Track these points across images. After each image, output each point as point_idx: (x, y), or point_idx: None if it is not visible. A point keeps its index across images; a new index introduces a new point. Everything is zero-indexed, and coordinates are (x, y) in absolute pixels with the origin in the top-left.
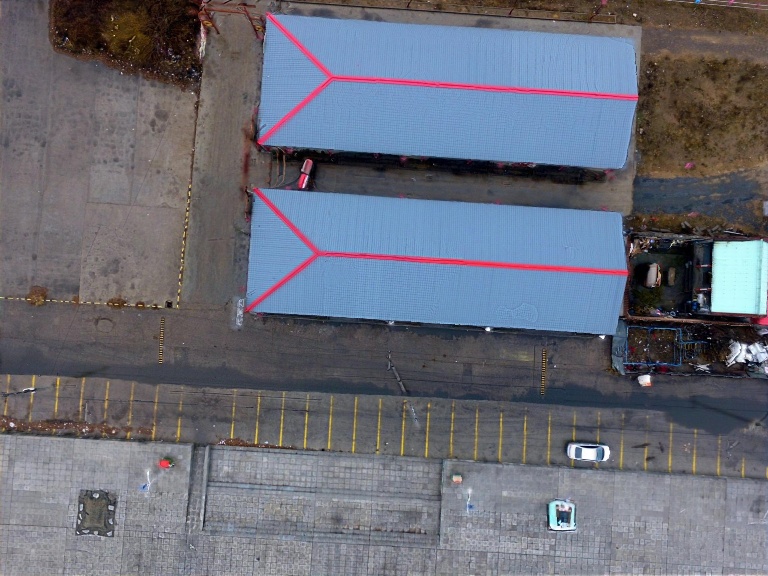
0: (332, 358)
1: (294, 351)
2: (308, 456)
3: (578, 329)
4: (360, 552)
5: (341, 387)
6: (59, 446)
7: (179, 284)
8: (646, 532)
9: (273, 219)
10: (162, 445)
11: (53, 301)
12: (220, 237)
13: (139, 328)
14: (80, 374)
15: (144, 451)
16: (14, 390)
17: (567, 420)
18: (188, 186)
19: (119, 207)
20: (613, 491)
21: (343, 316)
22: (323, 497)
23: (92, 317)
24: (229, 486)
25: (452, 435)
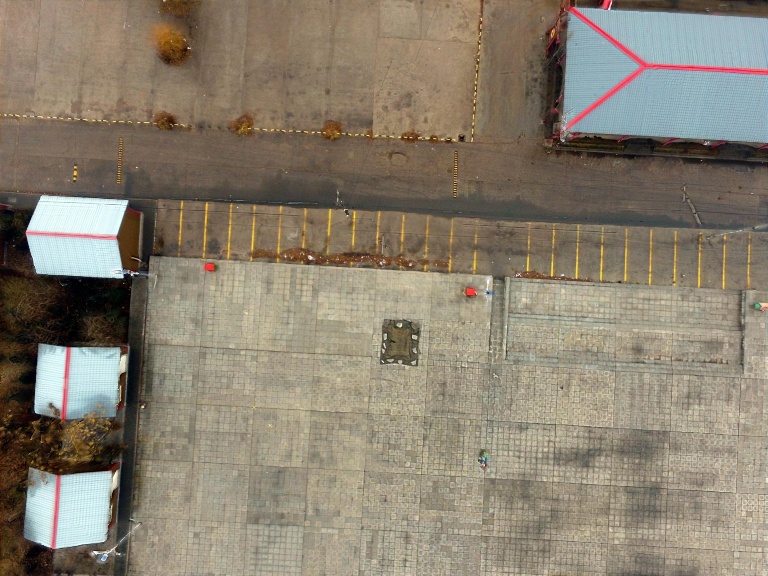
0: (626, 191)
1: (588, 184)
2: (606, 288)
3: None
4: (663, 381)
5: None
6: (362, 276)
7: (473, 117)
8: None
9: (593, 35)
10: (463, 275)
11: (348, 135)
12: (512, 70)
13: (433, 162)
14: (375, 208)
15: (446, 281)
16: (311, 224)
17: None
18: (479, 19)
19: (410, 41)
20: None
21: (660, 135)
22: (623, 327)
23: (386, 151)
24: (528, 317)
25: (749, 267)
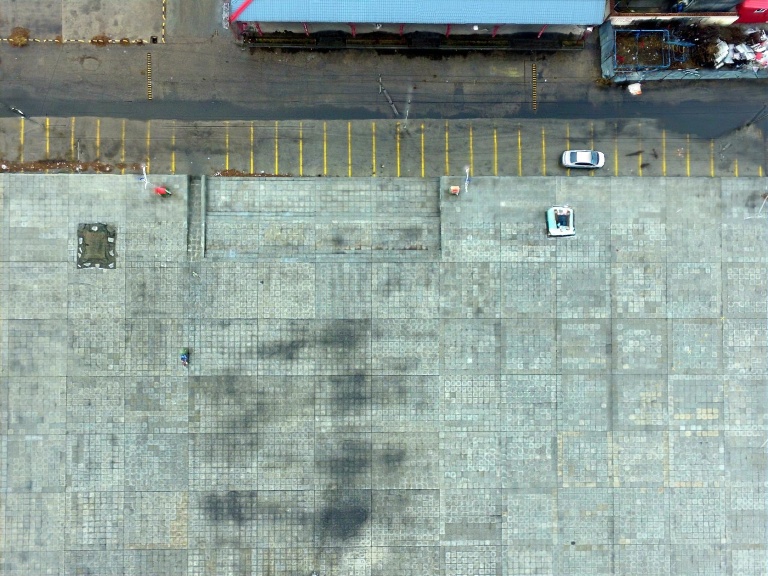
0: (322, 85)
1: (284, 79)
2: (305, 182)
3: (566, 20)
4: (363, 270)
5: (333, 113)
6: (53, 182)
7: (163, 17)
8: (644, 233)
9: None
10: (157, 175)
11: (36, 41)
12: None
13: (126, 65)
14: (69, 114)
15: (140, 182)
16: (4, 133)
17: (561, 132)
18: None
19: None
20: (610, 195)
21: (330, 20)
22: (323, 220)
23: (77, 56)
24: (228, 215)
25: (447, 154)
